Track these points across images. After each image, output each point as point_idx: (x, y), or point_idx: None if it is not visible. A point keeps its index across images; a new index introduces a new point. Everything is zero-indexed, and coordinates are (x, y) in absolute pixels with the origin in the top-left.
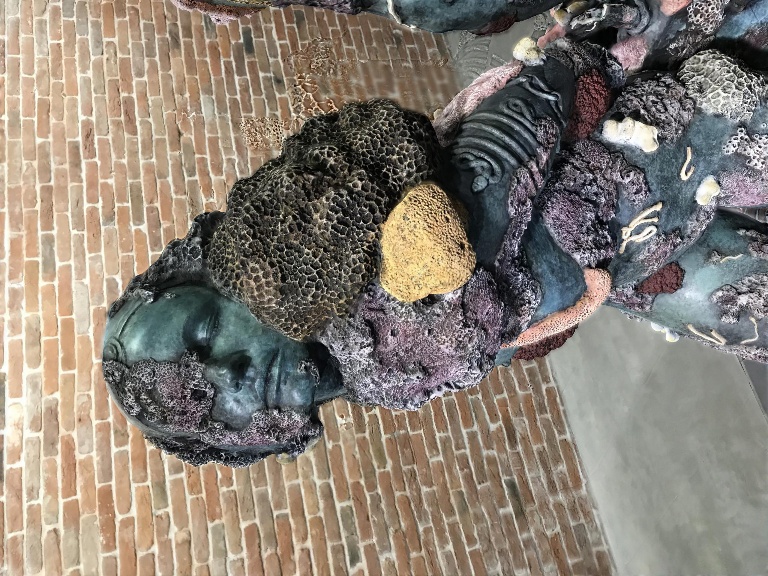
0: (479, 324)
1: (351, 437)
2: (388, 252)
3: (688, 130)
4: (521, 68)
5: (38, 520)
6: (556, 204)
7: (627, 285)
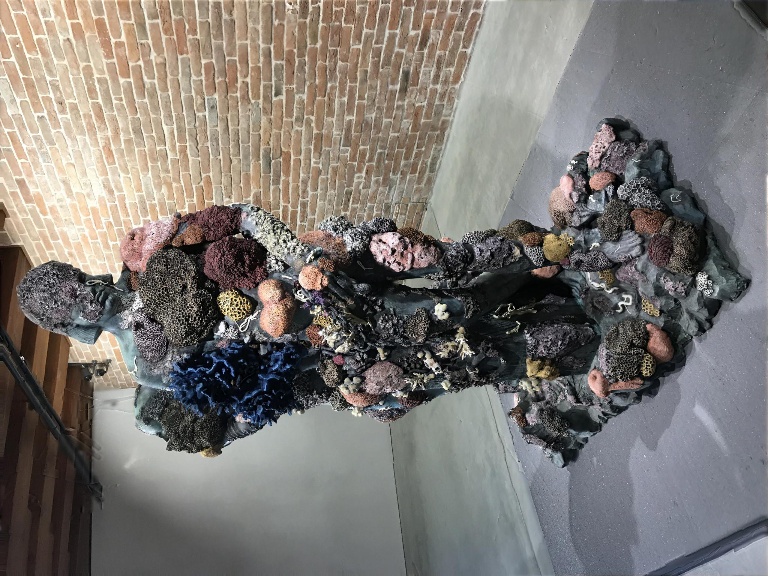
0: None
1: (294, 20)
2: None
3: None
4: None
5: (55, 31)
6: None
7: None
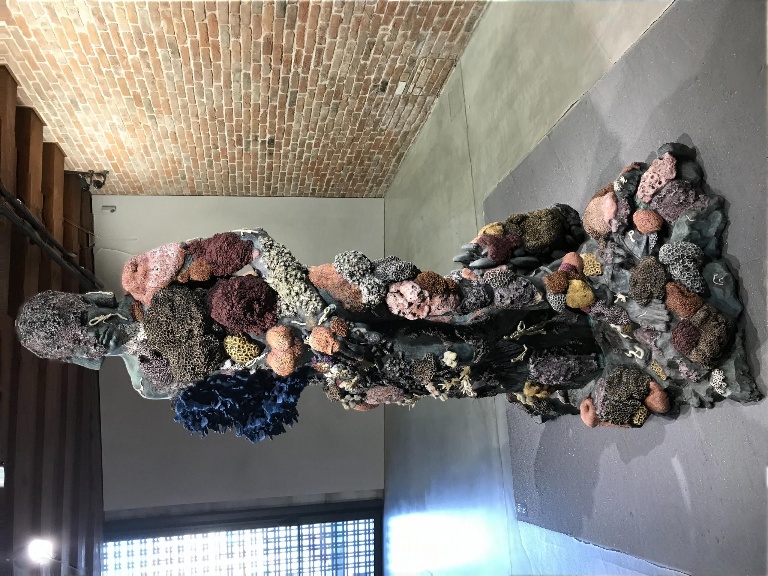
0: None
1: None
2: None
3: None
4: None
5: None
6: None
7: None
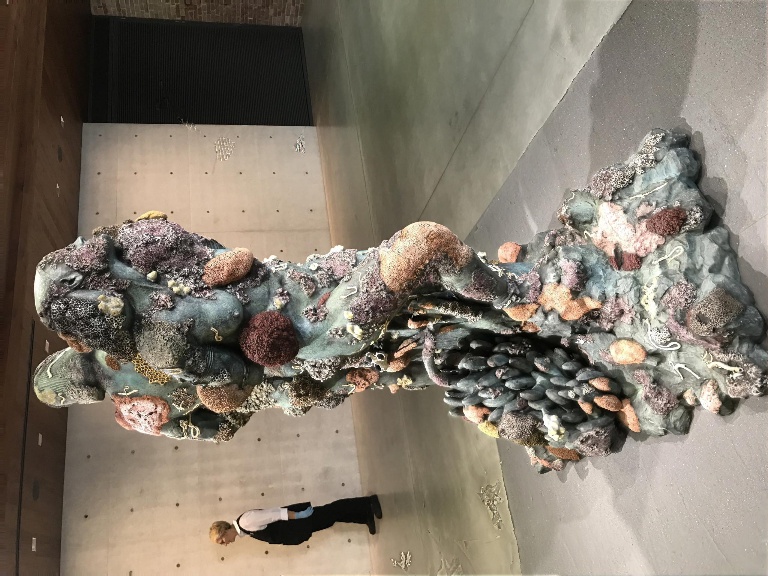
0: (171, 224)
1: None
2: None
3: None
4: None
5: None
6: None
7: None
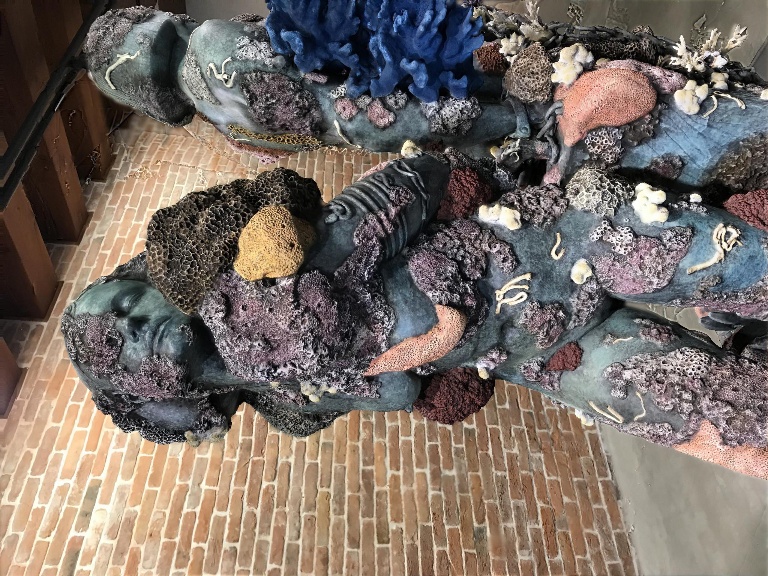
0: (311, 311)
1: None
2: (241, 245)
3: (559, 221)
4: (399, 159)
5: None
6: (421, 257)
7: (533, 360)
